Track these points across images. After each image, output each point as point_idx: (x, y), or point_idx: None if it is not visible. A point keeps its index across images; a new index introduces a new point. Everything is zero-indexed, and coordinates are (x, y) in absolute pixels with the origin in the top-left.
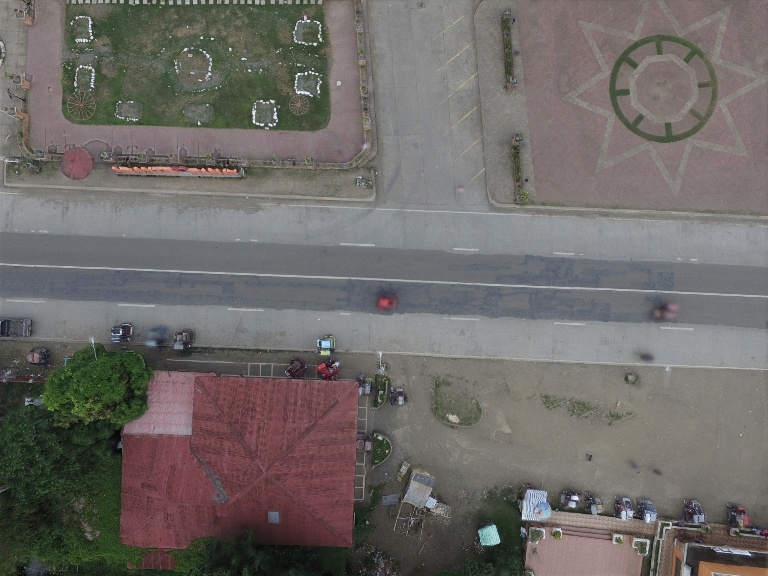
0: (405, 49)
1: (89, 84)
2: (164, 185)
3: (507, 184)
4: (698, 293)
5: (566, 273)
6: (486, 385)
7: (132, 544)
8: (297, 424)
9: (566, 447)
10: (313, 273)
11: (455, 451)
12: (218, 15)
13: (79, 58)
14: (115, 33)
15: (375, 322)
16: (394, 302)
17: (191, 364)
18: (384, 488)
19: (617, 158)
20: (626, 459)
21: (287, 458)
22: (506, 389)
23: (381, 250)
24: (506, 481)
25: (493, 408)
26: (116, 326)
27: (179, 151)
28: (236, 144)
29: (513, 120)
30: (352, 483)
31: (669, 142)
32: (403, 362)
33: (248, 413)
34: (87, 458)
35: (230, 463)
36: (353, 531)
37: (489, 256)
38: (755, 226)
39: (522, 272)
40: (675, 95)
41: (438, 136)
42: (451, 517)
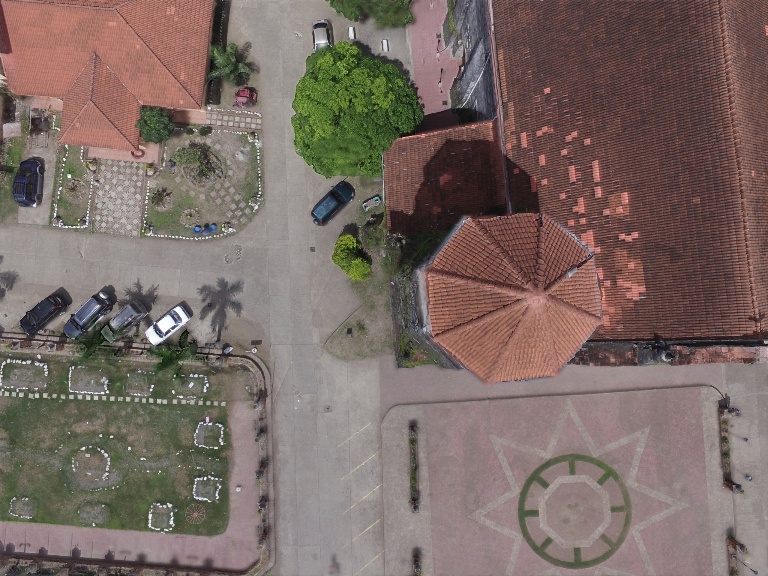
0: (309, 454)
1: None
2: None
3: None
4: None
5: None
6: None
7: None
8: None
9: None
10: None
11: None
12: (119, 412)
13: None
14: (13, 426)
15: None
16: None
17: None
18: None
19: None
20: None
21: None
22: None
23: None
24: None
25: None
26: None
27: (72, 551)
28: (131, 546)
29: (416, 537)
30: None
31: (577, 569)
32: None
33: None
34: None
35: None
36: None
37: None
38: None
39: None
40: (586, 519)
41: (338, 548)
42: None
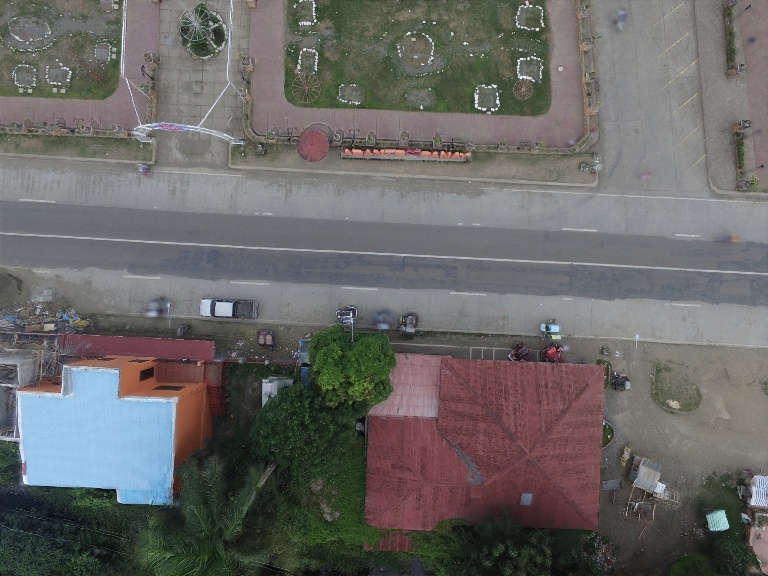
0: (625, 35)
1: (313, 67)
2: (388, 168)
3: (729, 171)
4: None
5: None
6: (706, 371)
7: (377, 525)
8: (552, 406)
9: None
10: (536, 258)
11: (674, 437)
12: None
13: (302, 41)
14: (338, 16)
15: (597, 307)
16: (616, 287)
17: (413, 348)
18: (604, 473)
19: None
20: None
21: (547, 440)
22: (725, 375)
23: (603, 235)
24: (725, 467)
25: (712, 394)
26: (341, 309)
27: (401, 135)
28: (457, 128)
29: (734, 107)
30: (599, 466)
31: None
32: (624, 347)
33: (501, 395)
34: None
35: (486, 444)
36: (598, 514)
37: (710, 242)
38: None
39: (743, 259)
40: None
41: (659, 122)
42: None
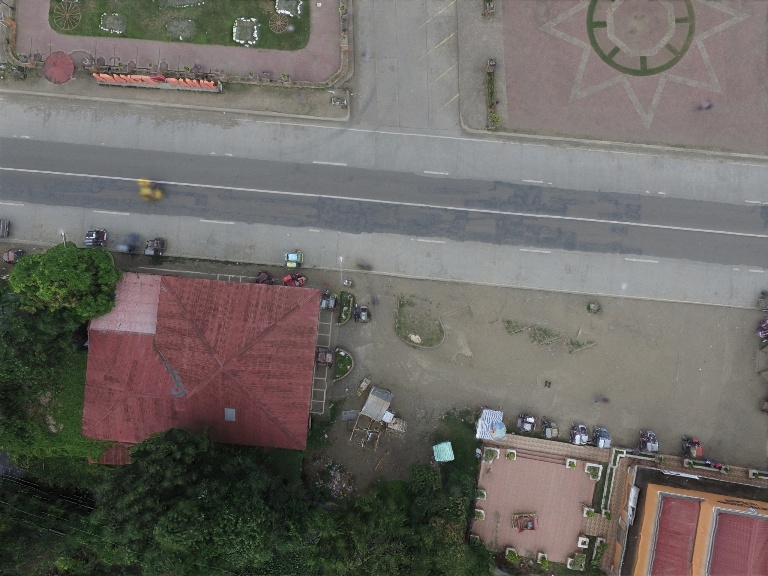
0: None
1: None
2: (144, 96)
3: (480, 110)
4: (664, 226)
5: (534, 201)
6: (449, 307)
7: (93, 436)
8: (257, 324)
9: (526, 373)
10: (285, 189)
11: (416, 371)
12: None
13: None
14: None
15: (343, 240)
16: (363, 221)
17: (162, 273)
18: (344, 403)
19: (590, 89)
20: (585, 388)
21: (245, 355)
22: (469, 313)
23: (352, 170)
24: (465, 403)
25: (455, 331)
26: (91, 231)
27: (160, 65)
28: (216, 60)
29: (489, 47)
30: (309, 387)
31: (643, 76)
32: (369, 281)
33: (210, 312)
34: (54, 351)
35: (190, 358)
36: (308, 434)
37: (459, 180)
38: (725, 163)
39: (490, 198)
40: (652, 29)
41: (414, 60)
42: (409, 435)
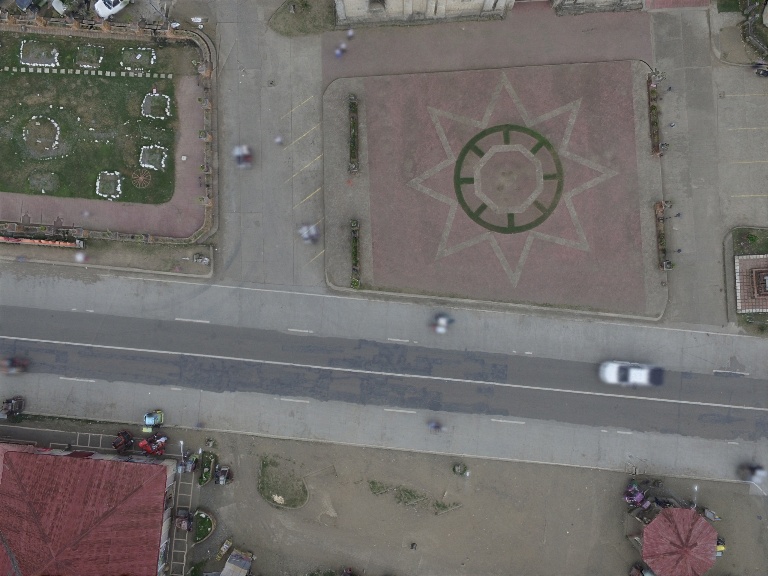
0: (253, 127)
1: None
2: (4, 251)
3: (345, 267)
4: (531, 387)
5: (399, 360)
6: (313, 468)
7: None
8: (96, 508)
9: (391, 534)
10: (146, 347)
11: (279, 532)
12: (69, 84)
13: None
14: None
15: (205, 399)
16: (225, 380)
17: (21, 431)
18: (206, 565)
19: (457, 247)
20: (451, 550)
21: (81, 543)
22: (334, 473)
23: (216, 327)
24: (329, 565)
25: (320, 491)
26: None
27: (22, 218)
28: (79, 213)
29: (355, 203)
30: (154, 567)
31: (510, 233)
32: (231, 440)
33: (50, 493)
34: None
35: (27, 543)
36: None
37: (323, 339)
38: (593, 322)
39: (355, 356)
40: (520, 186)
41: (280, 215)
42: None
